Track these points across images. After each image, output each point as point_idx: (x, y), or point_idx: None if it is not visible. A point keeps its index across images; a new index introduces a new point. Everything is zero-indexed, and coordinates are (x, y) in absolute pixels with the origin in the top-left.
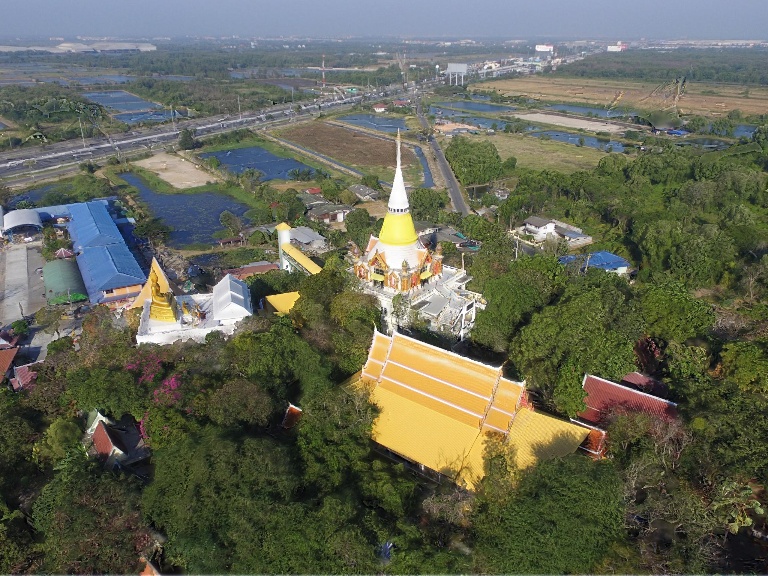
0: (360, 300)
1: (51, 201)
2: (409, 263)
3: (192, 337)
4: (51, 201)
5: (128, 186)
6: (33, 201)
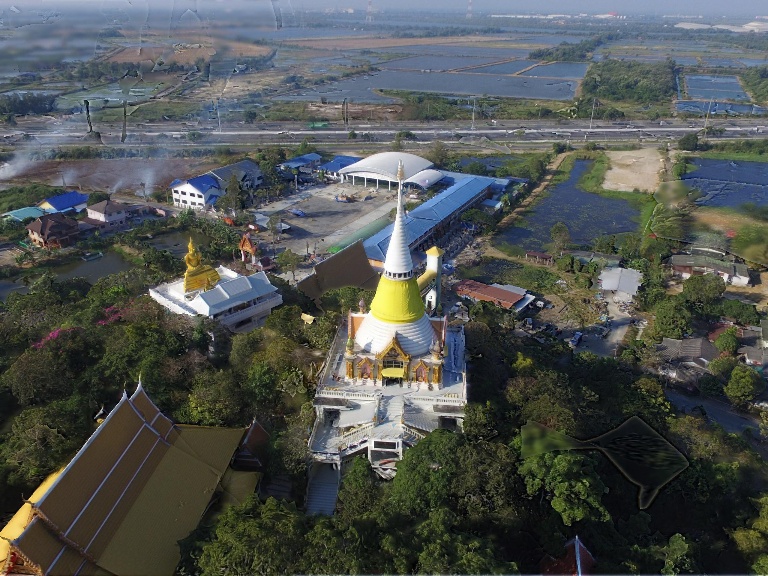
0: (275, 355)
1: (473, 169)
2: (373, 345)
3: (175, 311)
4: (473, 169)
5: (564, 173)
6: (462, 166)
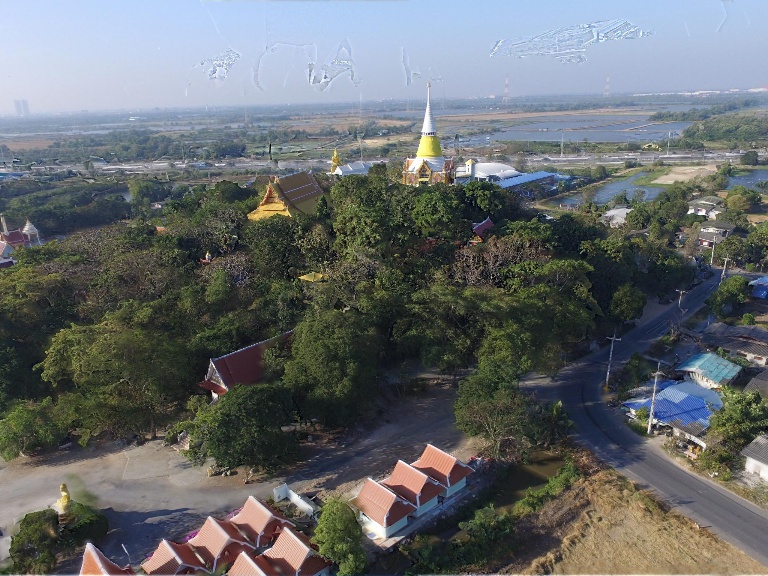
0: None
1: None
2: None
3: None
4: None
5: (625, 177)
6: None
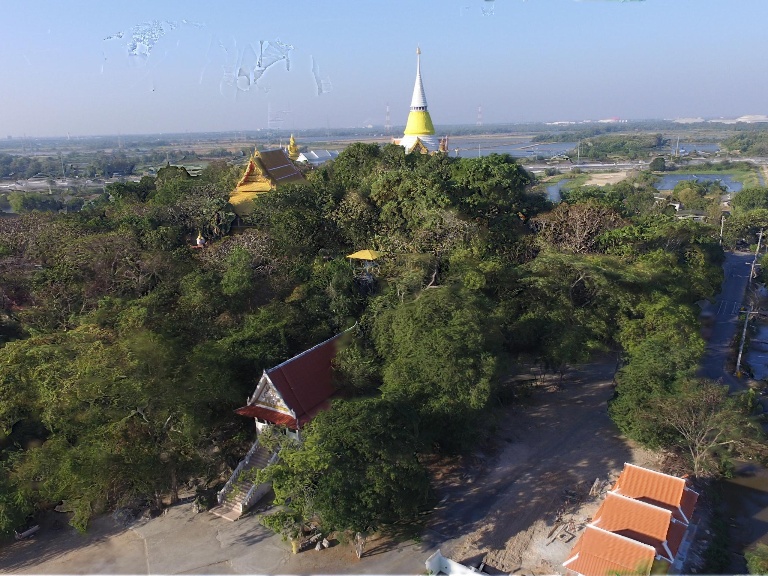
0: None
1: None
2: (406, 148)
3: None
4: None
5: (553, 182)
6: None
